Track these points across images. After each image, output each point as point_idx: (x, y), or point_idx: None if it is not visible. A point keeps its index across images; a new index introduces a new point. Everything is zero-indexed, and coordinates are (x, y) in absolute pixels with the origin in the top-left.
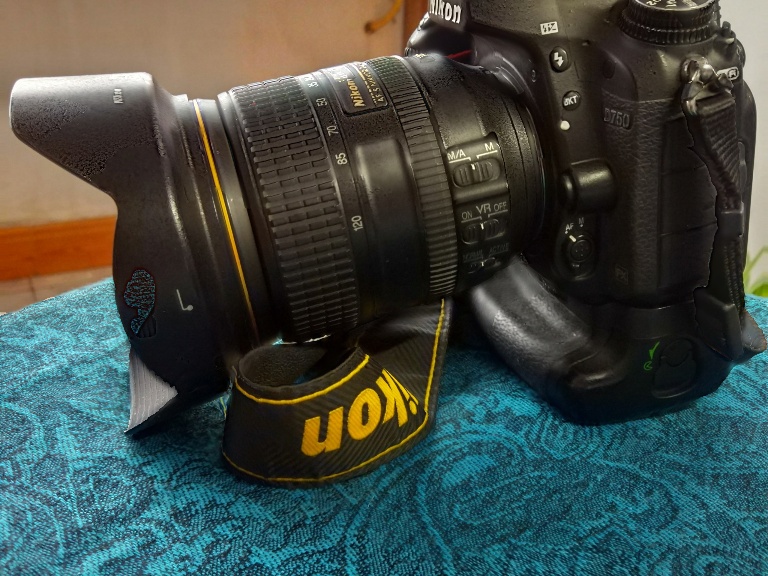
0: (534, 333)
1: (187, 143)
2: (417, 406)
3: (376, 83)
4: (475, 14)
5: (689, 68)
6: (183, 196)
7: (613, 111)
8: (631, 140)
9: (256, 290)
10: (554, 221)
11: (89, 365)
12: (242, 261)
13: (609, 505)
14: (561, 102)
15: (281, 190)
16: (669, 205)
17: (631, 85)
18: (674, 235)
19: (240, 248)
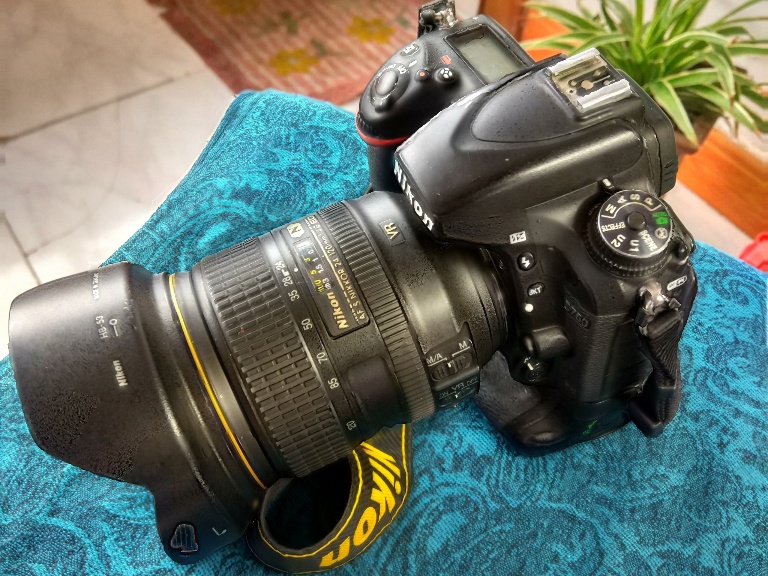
0: (491, 383)
1: (193, 399)
2: (400, 482)
3: (355, 293)
4: (447, 233)
5: (644, 296)
6: (203, 460)
7: (573, 309)
8: (588, 335)
9: (269, 479)
10: (515, 353)
11: None
12: (257, 473)
13: (553, 555)
14: (526, 292)
15: (284, 421)
16: (615, 361)
17: (592, 303)
18: (617, 373)
19: (254, 467)
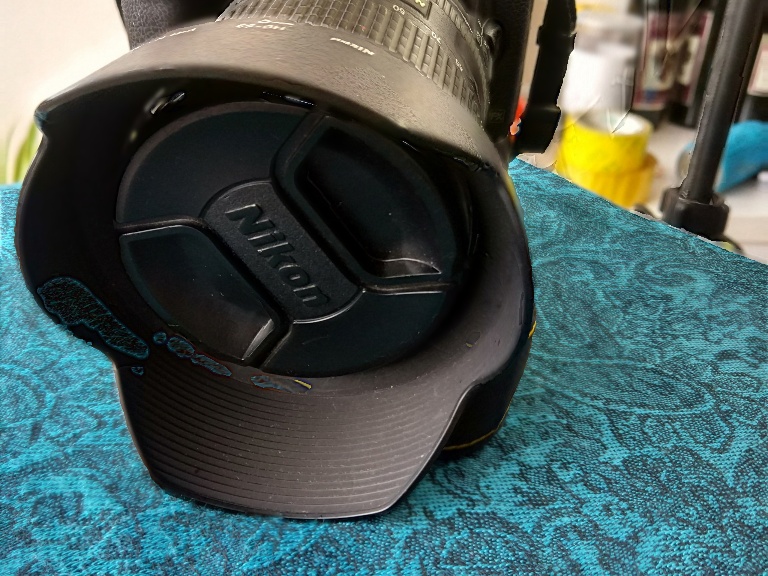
0: None
1: None
2: None
3: None
4: None
5: None
6: None
7: None
8: None
9: None
10: None
11: (150, 536)
12: None
13: (581, 283)
14: None
15: None
16: None
17: None
18: None
19: None
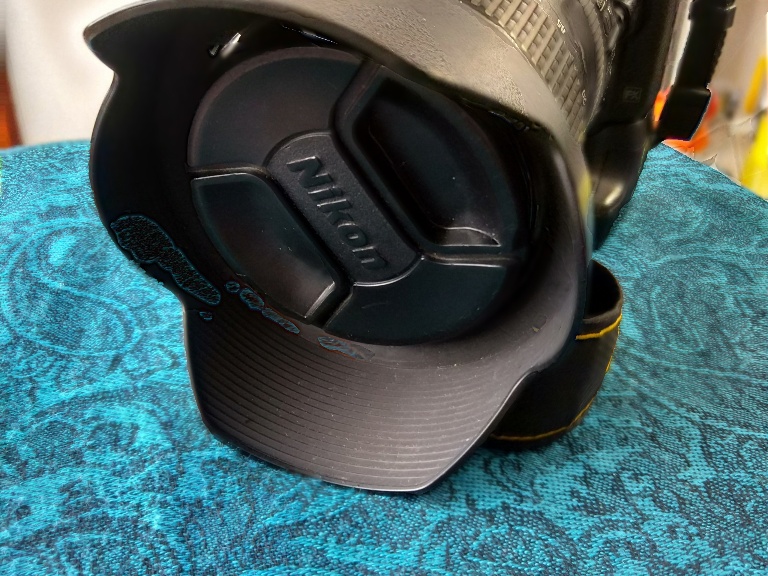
0: None
1: None
2: None
3: None
4: None
5: None
6: None
7: None
8: None
9: None
10: None
11: (188, 476)
12: None
13: (711, 286)
14: None
15: (554, 79)
16: None
17: None
18: None
19: None
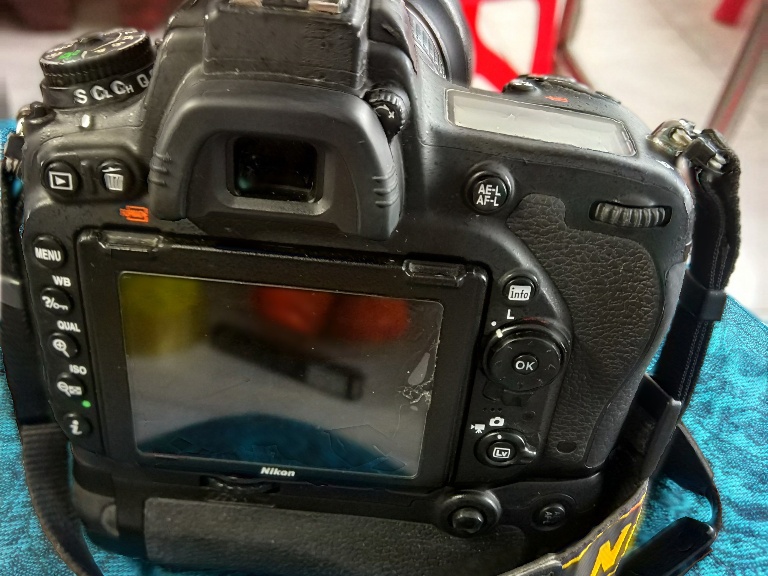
0: None
1: None
2: None
3: None
4: None
5: None
6: None
7: None
8: None
9: None
10: None
11: None
12: None
13: None
14: None
15: None
16: None
17: None
18: None
19: None
